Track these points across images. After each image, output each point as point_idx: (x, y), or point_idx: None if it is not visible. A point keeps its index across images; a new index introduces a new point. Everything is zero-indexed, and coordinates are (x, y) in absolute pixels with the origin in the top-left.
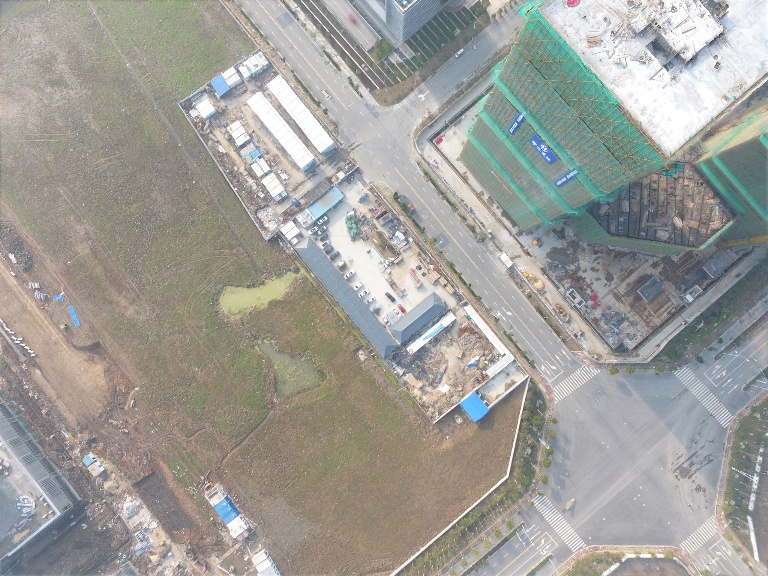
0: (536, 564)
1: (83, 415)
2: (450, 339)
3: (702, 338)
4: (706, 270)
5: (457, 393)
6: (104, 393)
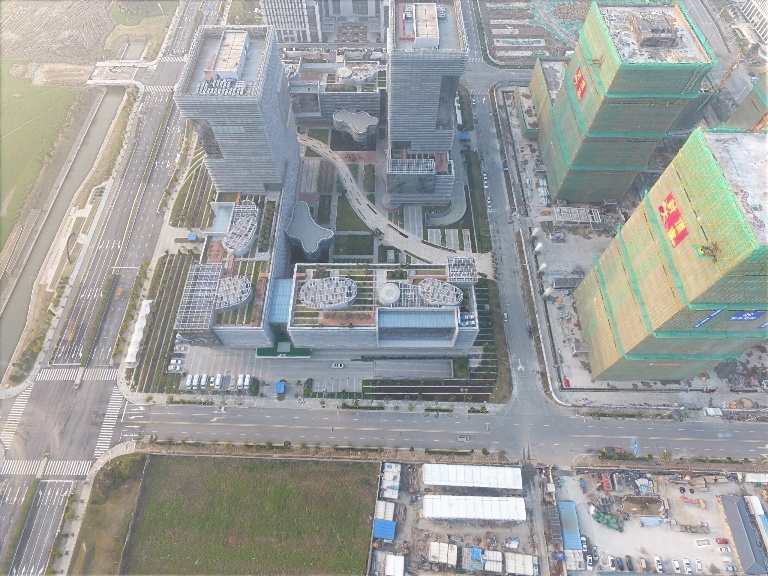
0: None
1: None
2: None
3: None
4: None
5: None
6: None
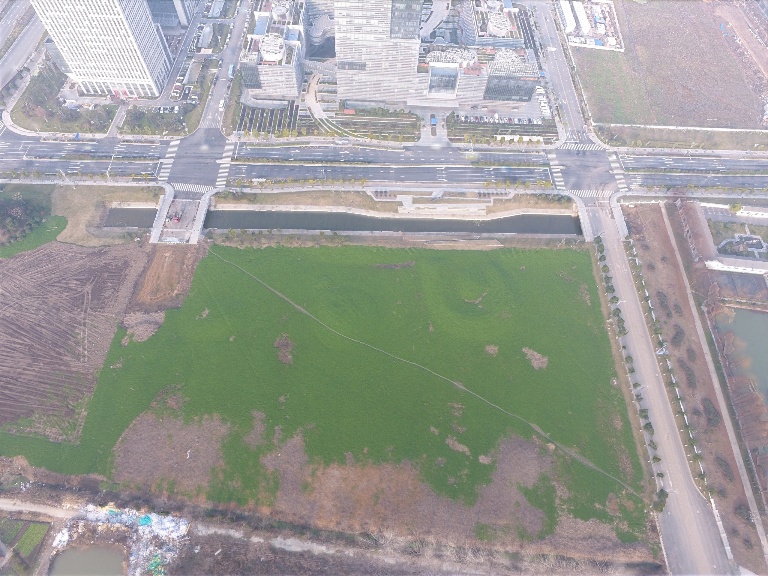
0: None
1: (733, 8)
2: None
3: None
4: None
5: None
6: (719, 8)
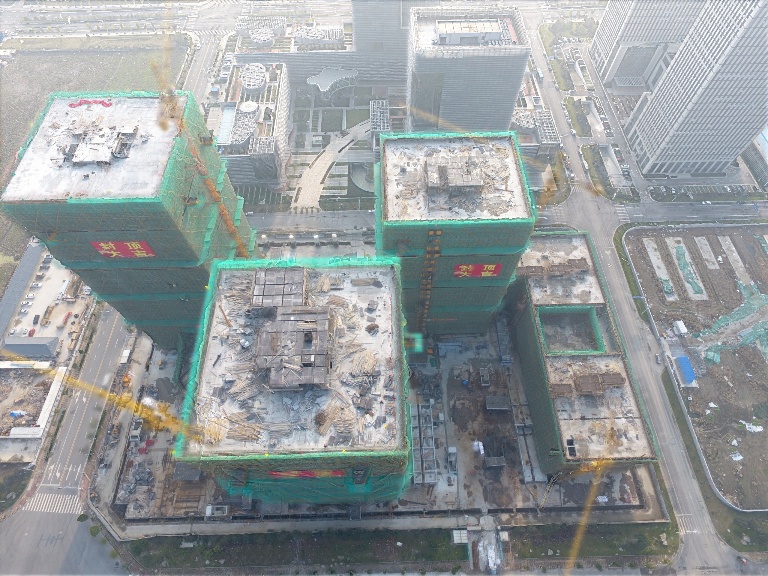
0: None
1: None
2: (29, 382)
3: (184, 564)
4: (243, 495)
5: None
6: None
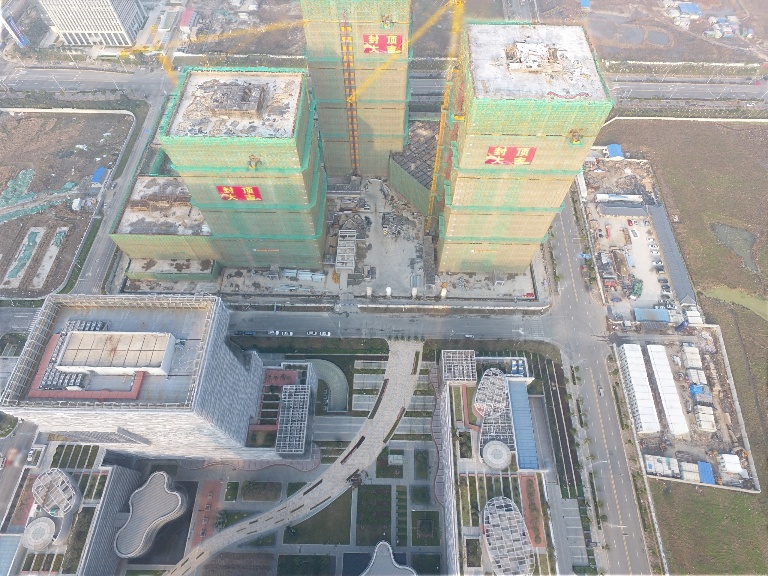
0: (625, 83)
1: None
2: (606, 190)
3: None
4: None
5: (621, 164)
6: None
